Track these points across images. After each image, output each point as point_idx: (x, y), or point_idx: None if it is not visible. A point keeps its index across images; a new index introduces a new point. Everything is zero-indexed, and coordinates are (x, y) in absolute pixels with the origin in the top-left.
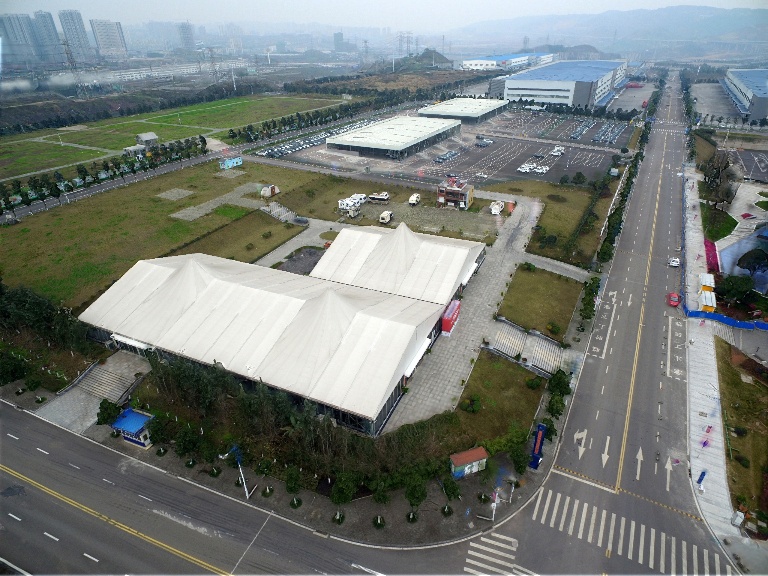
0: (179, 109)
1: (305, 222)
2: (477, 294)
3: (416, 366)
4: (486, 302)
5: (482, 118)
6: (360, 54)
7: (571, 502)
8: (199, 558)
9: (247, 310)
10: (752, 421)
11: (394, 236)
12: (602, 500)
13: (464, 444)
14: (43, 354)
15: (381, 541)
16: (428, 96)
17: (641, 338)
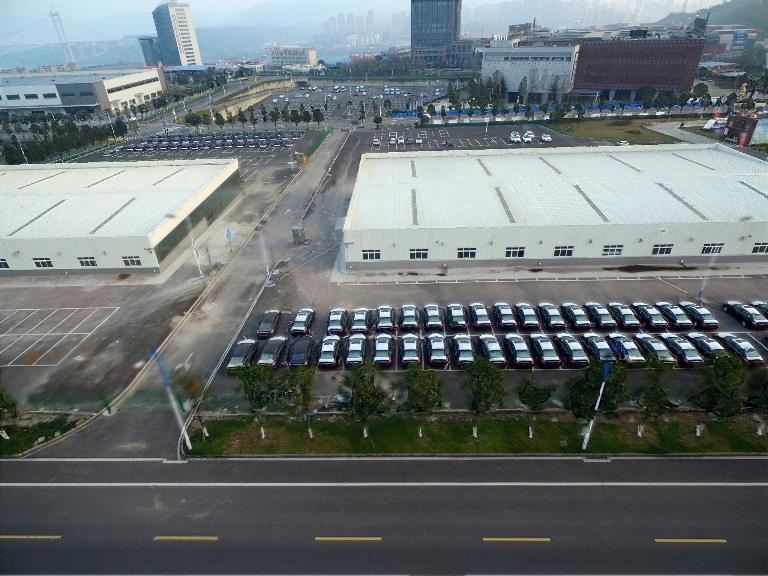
0: None
1: None
2: None
3: None
4: None
5: None
6: None
7: None
8: None
9: None
10: None
11: None
12: None
13: None
14: None
15: None
16: None
17: None
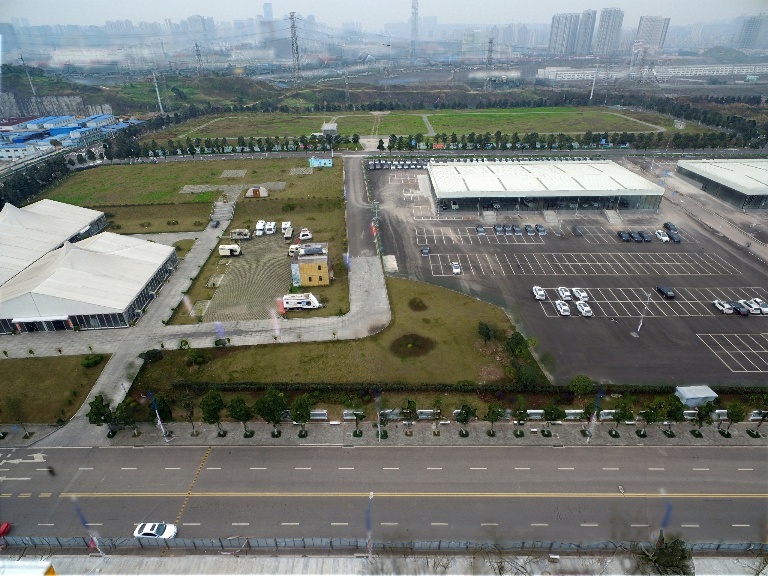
0: (484, 110)
1: (212, 226)
2: (24, 341)
3: None
4: (2, 350)
5: None
6: None
7: None
8: None
9: None
10: None
11: None
12: None
13: None
14: None
15: None
16: None
17: None
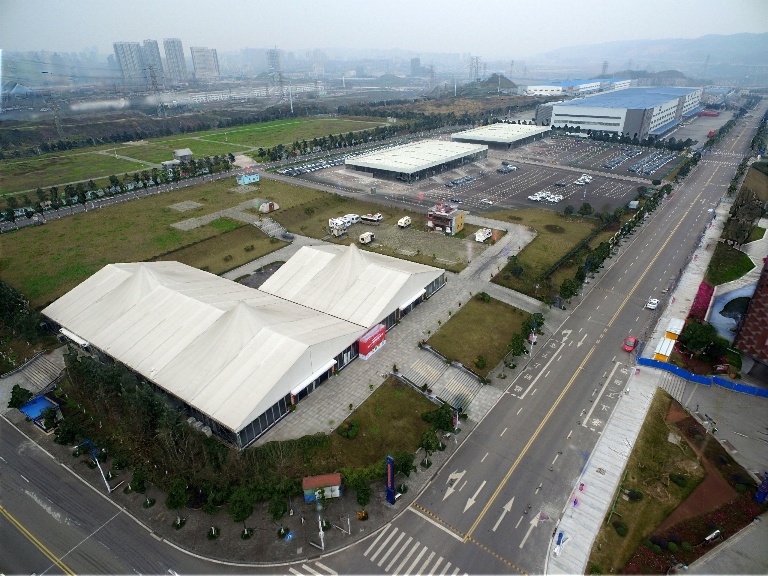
0: (234, 128)
1: (290, 238)
2: (417, 320)
3: (315, 385)
4: (422, 329)
5: (516, 144)
6: (426, 79)
7: (411, 543)
8: (40, 540)
9: (174, 316)
10: (655, 486)
11: (343, 256)
12: (445, 546)
13: (329, 468)
14: (7, 340)
15: (206, 552)
16: (470, 121)
17: (573, 382)
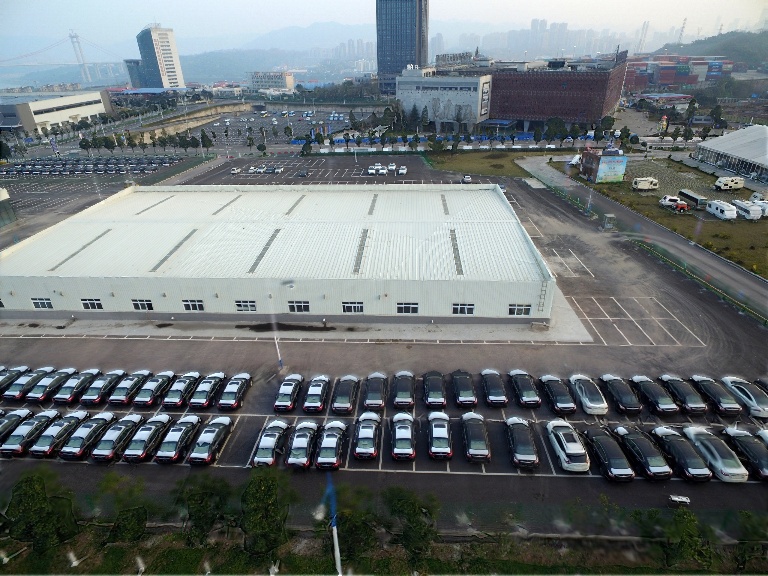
0: None
1: None
2: None
3: None
4: None
5: None
6: None
7: None
8: None
9: None
10: None
11: None
12: None
13: None
14: None
15: None
16: None
17: None
